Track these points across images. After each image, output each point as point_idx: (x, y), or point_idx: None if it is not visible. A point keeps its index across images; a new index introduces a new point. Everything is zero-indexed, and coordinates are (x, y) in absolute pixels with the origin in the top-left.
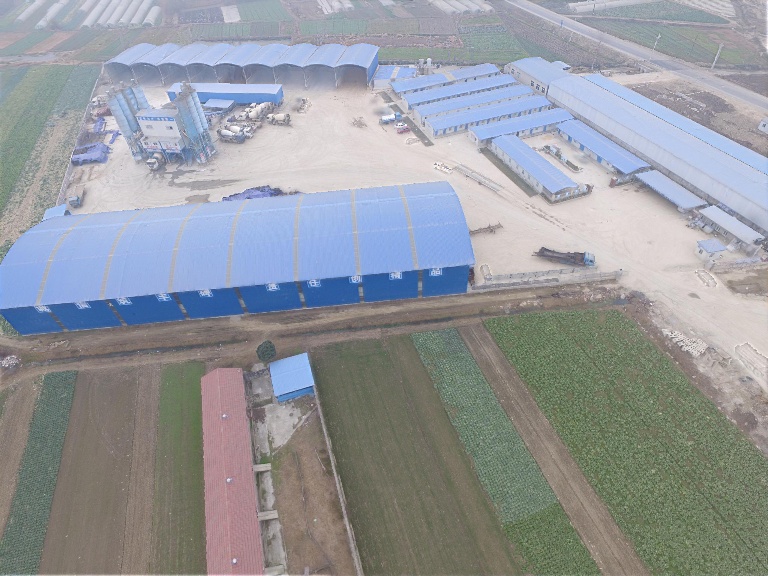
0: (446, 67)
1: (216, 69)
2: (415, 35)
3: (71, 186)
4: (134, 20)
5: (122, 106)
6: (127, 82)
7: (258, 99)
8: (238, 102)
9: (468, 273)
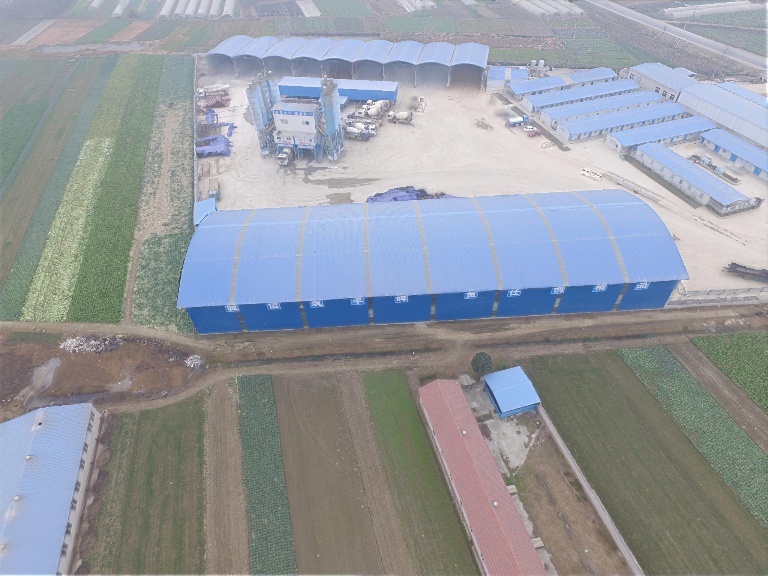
0: (559, 70)
1: (323, 64)
2: (509, 36)
3: (202, 179)
4: (213, 11)
5: (259, 99)
6: (225, 74)
7: (374, 96)
8: (352, 98)
9: None
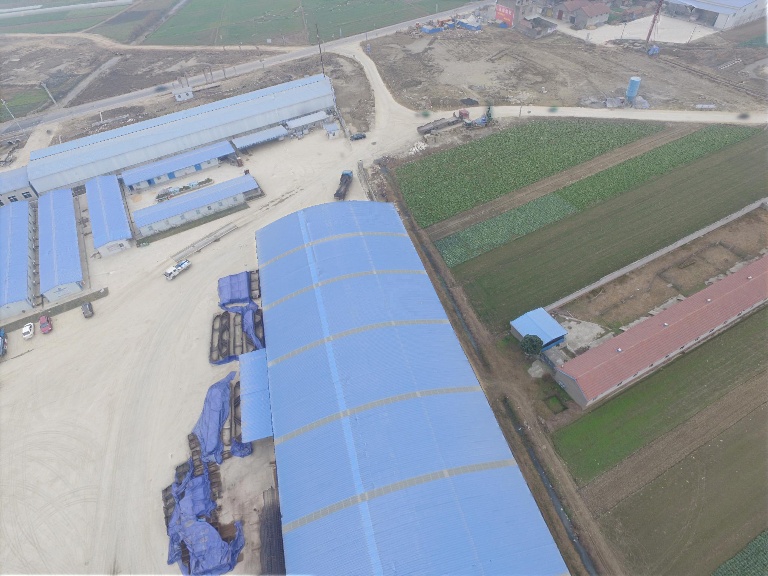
0: None
1: None
2: None
3: None
4: None
5: None
6: None
7: None
8: None
9: None
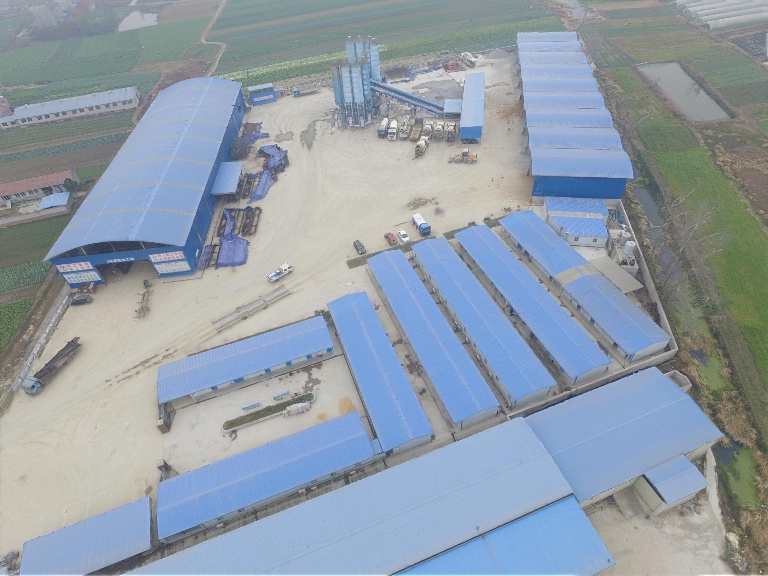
0: (626, 273)
1: None
2: None
3: (326, 87)
4: (710, 16)
5: (358, 53)
6: None
7: None
8: None
9: (59, 270)
